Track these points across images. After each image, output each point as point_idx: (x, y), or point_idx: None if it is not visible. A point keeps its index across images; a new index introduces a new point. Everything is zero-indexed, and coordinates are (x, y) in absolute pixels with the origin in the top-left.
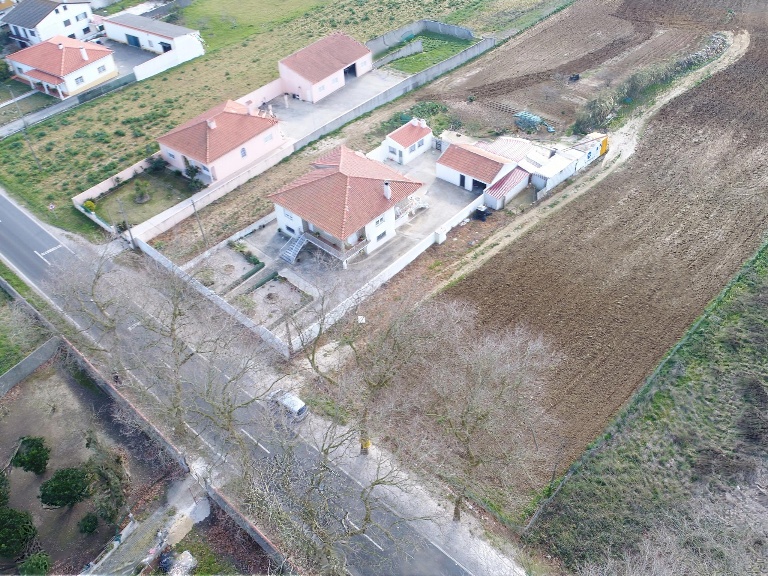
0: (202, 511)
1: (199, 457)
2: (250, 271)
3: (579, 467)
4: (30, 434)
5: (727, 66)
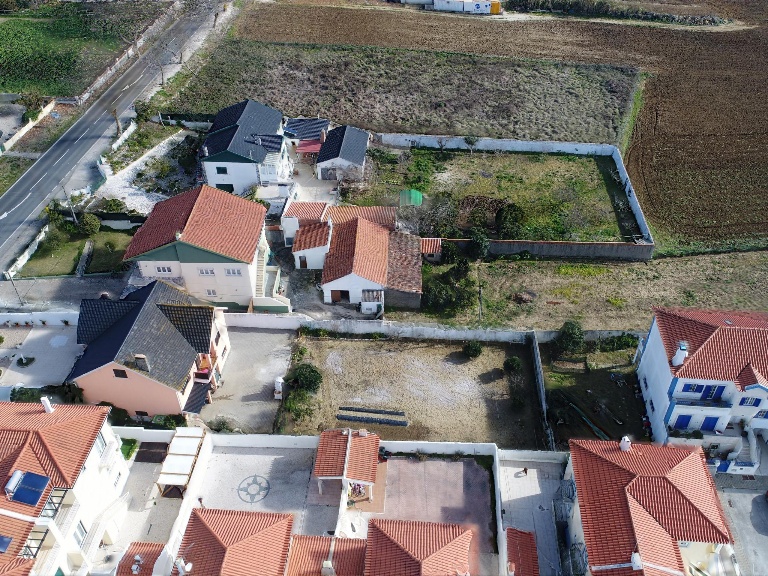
0: None
1: None
2: None
3: (261, 41)
4: None
5: (683, 29)
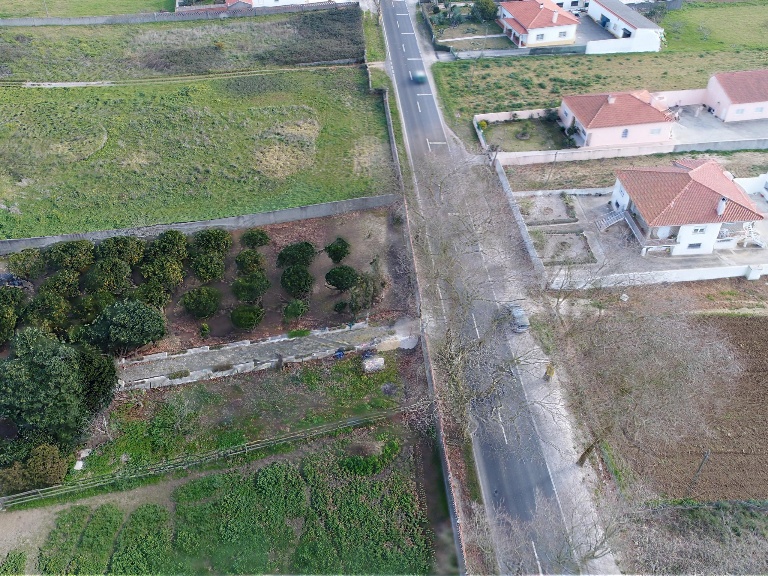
0: (410, 343)
1: (431, 310)
2: (562, 219)
3: (725, 507)
4: (347, 242)
5: None
